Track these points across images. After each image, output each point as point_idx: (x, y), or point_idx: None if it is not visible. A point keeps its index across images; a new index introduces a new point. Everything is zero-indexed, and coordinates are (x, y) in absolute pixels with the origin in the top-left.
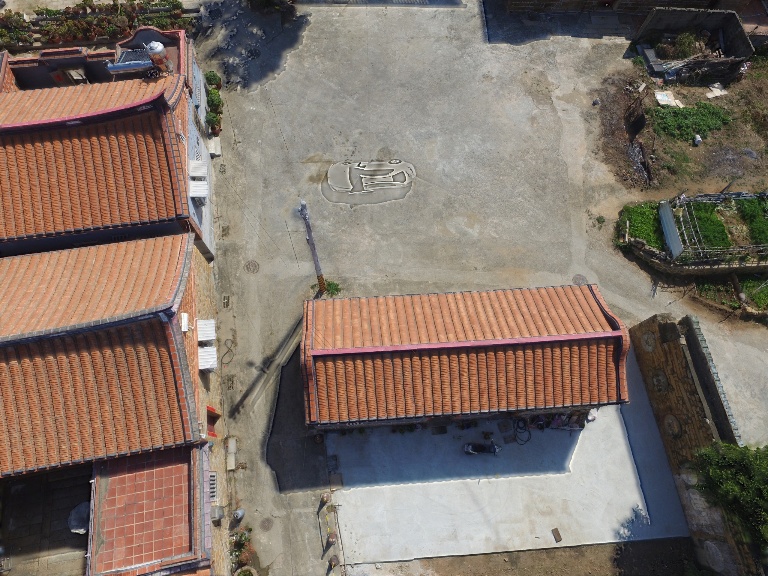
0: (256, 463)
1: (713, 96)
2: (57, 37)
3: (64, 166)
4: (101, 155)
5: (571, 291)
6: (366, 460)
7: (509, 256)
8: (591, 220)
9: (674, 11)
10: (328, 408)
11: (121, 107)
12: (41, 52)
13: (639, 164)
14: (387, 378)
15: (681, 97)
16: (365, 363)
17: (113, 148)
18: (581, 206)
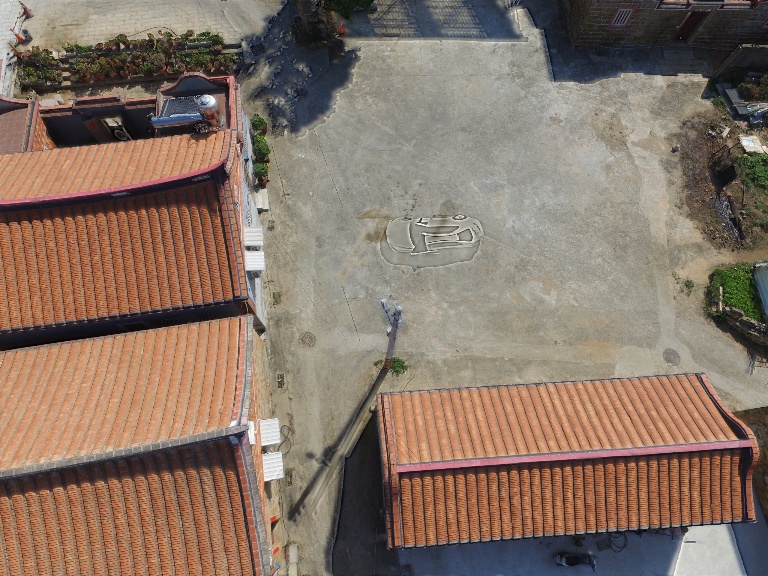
0: (321, 575)
1: None
2: (88, 76)
3: (108, 242)
4: (150, 229)
5: (679, 383)
6: (444, 570)
7: (591, 328)
8: (678, 285)
9: (761, 49)
10: (414, 530)
11: (174, 177)
12: (75, 100)
13: (728, 220)
14: (481, 495)
15: None
16: (456, 478)
17: (163, 222)
18: (667, 269)
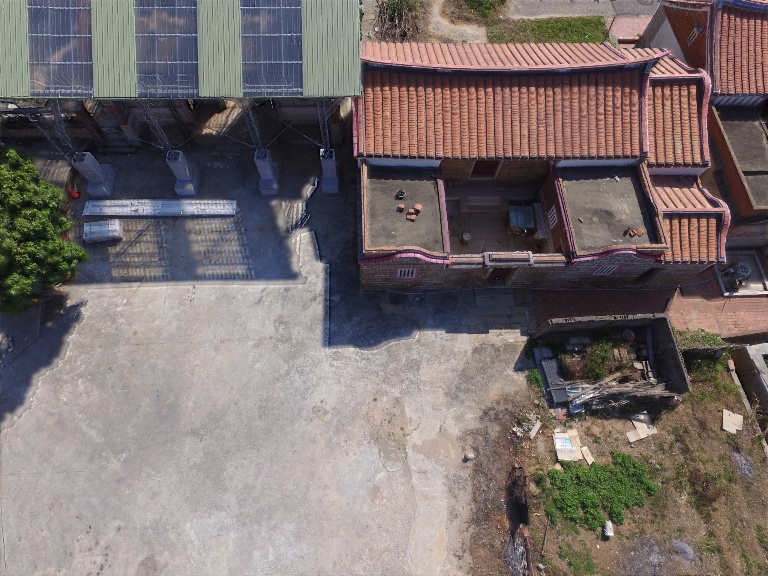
0: None
1: (636, 438)
2: None
3: None
4: None
5: None
6: None
7: None
8: None
9: (579, 322)
10: None
11: None
12: None
13: None
14: None
15: (591, 441)
16: None
17: None
18: None
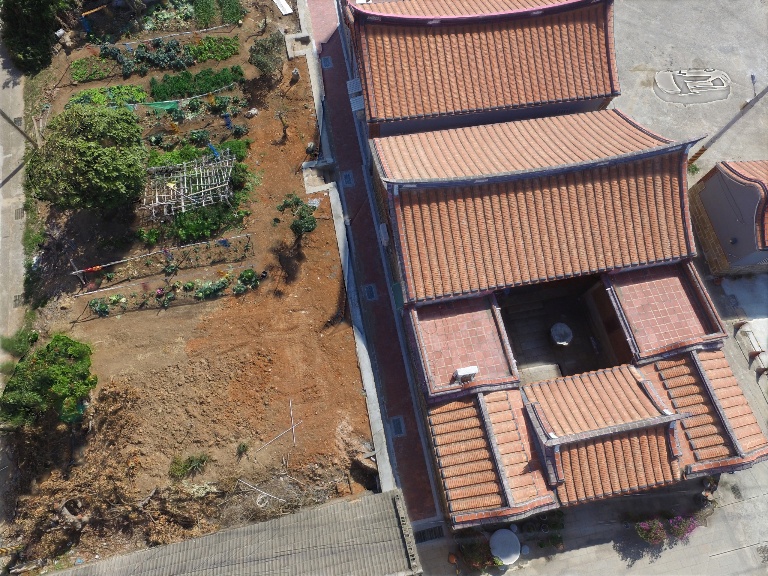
0: None
1: None
2: None
3: (524, 50)
4: (553, 41)
5: None
6: (758, 298)
7: None
8: None
9: None
10: None
11: None
12: None
13: None
14: None
15: None
16: None
17: (564, 35)
18: None
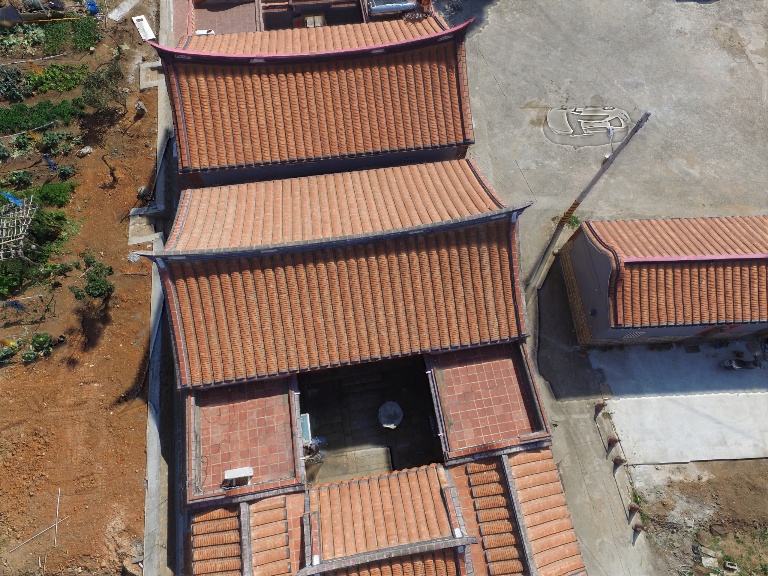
0: None
1: None
2: None
3: (364, 92)
4: (397, 83)
5: None
6: (629, 374)
7: (733, 194)
8: None
9: None
10: (631, 313)
11: (425, 36)
12: None
13: None
14: (685, 287)
15: None
16: (666, 272)
17: (409, 76)
18: None
